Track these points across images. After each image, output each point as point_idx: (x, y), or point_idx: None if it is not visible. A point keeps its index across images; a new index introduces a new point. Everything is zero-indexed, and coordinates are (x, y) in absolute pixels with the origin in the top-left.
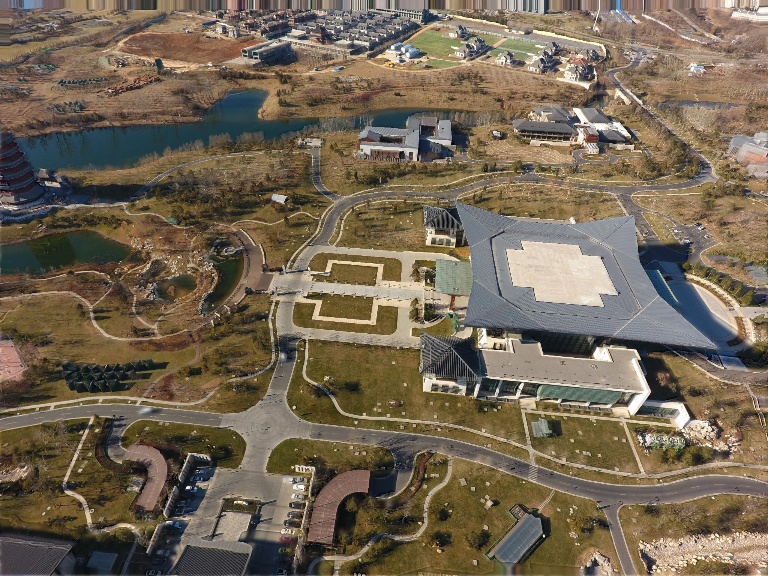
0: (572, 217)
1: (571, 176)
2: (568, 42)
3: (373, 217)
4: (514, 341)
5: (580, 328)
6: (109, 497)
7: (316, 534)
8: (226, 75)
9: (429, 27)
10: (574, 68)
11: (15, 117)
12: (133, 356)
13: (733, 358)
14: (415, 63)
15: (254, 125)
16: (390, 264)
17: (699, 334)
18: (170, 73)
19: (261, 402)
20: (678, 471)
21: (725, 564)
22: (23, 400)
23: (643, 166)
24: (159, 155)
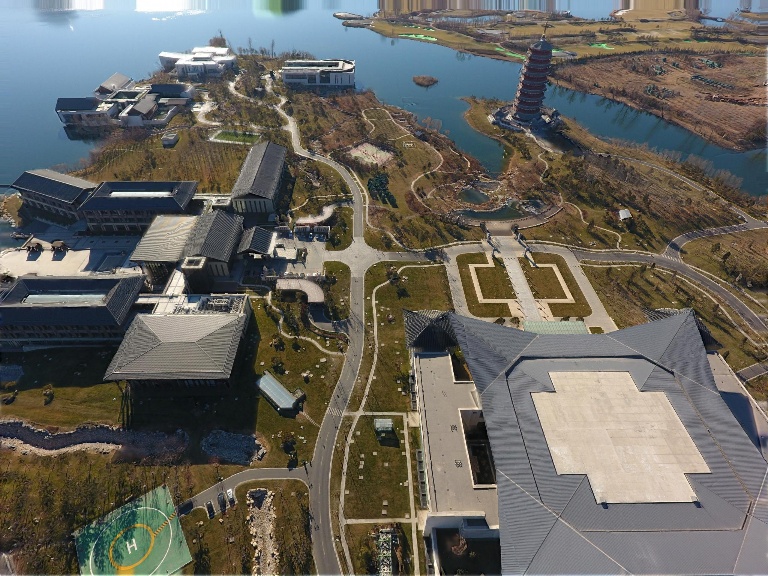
0: None
1: None
2: None
3: (659, 286)
4: (472, 385)
5: (496, 430)
6: (305, 212)
7: (281, 282)
8: None
9: None
10: None
11: (619, 83)
12: (399, 194)
13: None
14: None
15: None
16: (579, 307)
17: None
18: None
19: (376, 250)
20: (352, 568)
21: None
22: (359, 172)
23: None
24: (634, 145)
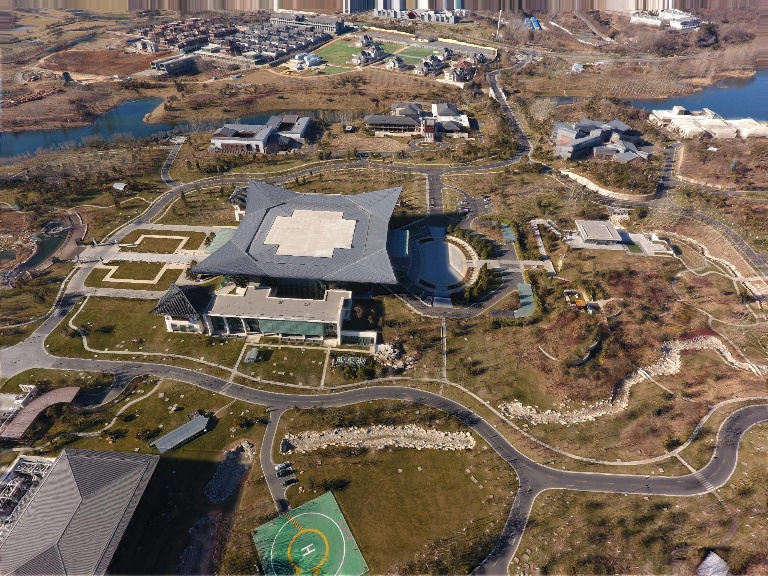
0: (363, 192)
1: (397, 161)
2: (466, 48)
3: None
4: (249, 288)
5: (298, 273)
6: None
7: (10, 431)
8: (129, 85)
9: (340, 38)
10: (452, 70)
11: None
12: None
13: (445, 298)
14: (312, 70)
15: (137, 128)
16: (195, 236)
17: (390, 273)
18: (74, 85)
19: (21, 343)
20: (353, 384)
21: (350, 448)
22: None
23: (467, 151)
24: (31, 154)
